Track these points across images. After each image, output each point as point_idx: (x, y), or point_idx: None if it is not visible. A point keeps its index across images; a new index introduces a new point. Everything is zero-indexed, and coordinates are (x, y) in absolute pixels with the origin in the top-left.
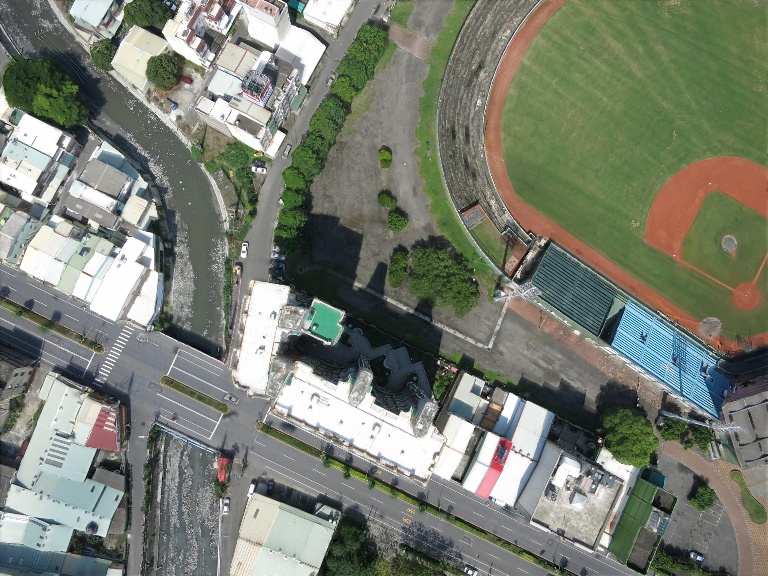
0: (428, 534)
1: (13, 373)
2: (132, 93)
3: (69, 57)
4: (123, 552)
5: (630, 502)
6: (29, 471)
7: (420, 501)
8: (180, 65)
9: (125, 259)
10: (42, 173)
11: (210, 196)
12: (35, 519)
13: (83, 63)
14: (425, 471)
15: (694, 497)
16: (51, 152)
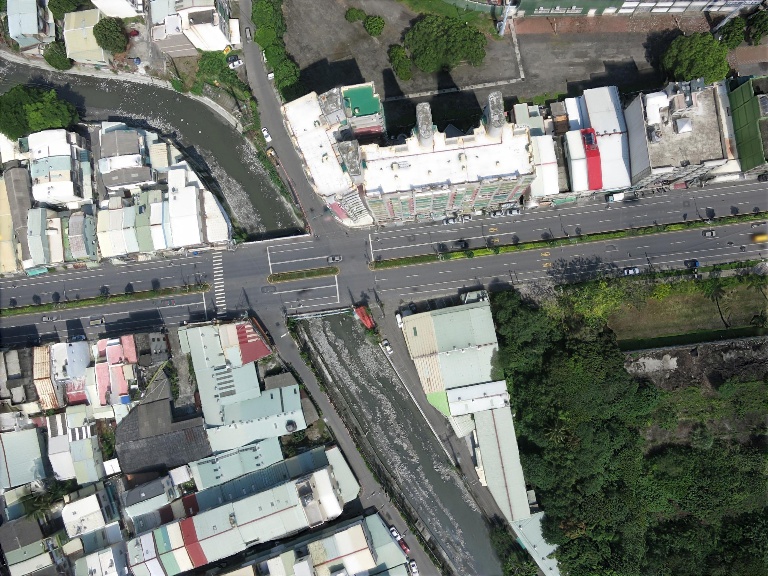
0: (573, 264)
1: (150, 338)
2: (99, 77)
3: (34, 83)
4: (329, 434)
5: (735, 118)
6: (213, 412)
7: (548, 241)
8: (120, 26)
9: (176, 190)
10: (71, 173)
11: (212, 115)
12: (242, 448)
13: (47, 80)
14: (527, 166)
15: None
16: (67, 152)
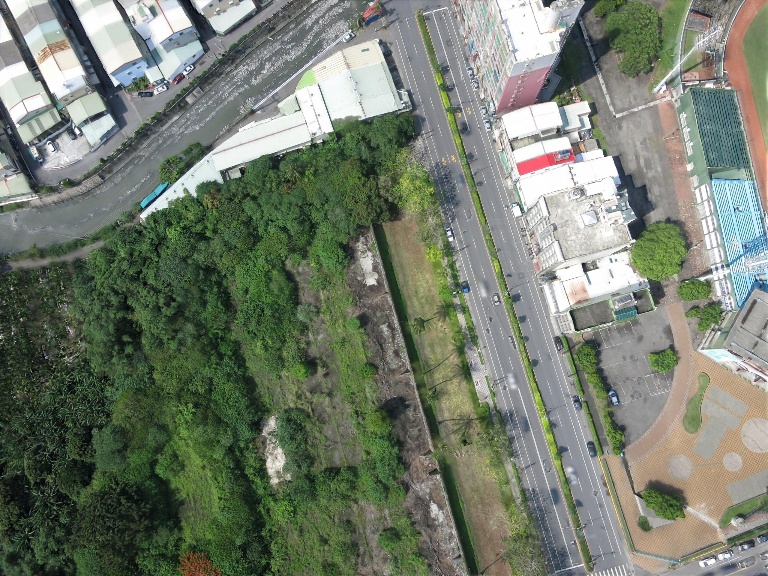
0: (448, 184)
1: None
2: None
3: None
4: (265, 2)
5: None
6: None
7: (466, 158)
8: None
9: None
10: None
11: None
12: None
13: None
14: (523, 58)
15: (657, 353)
16: None
